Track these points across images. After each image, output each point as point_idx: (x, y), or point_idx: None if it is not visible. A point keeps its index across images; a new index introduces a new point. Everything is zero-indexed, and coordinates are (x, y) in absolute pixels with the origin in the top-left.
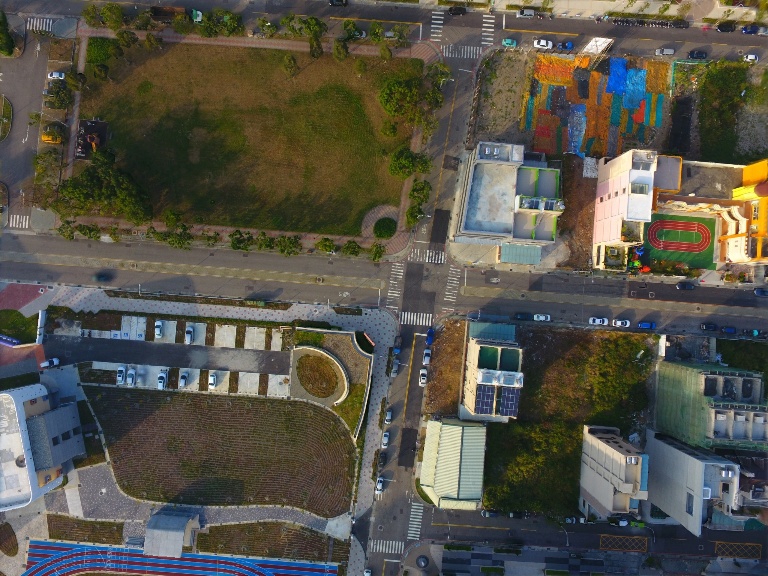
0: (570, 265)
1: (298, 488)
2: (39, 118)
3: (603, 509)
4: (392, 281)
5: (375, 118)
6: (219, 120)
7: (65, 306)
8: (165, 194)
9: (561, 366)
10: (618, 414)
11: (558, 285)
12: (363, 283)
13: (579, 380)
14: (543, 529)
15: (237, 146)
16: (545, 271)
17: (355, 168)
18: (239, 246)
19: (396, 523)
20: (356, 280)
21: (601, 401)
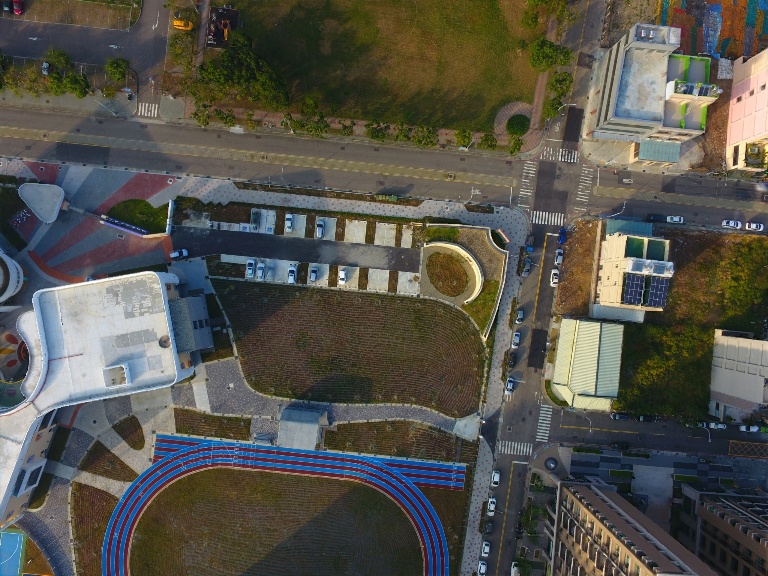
0: (704, 166)
1: (427, 387)
2: (174, 0)
3: (748, 404)
4: (524, 179)
5: (509, 13)
6: (351, 11)
7: (194, 197)
8: (296, 85)
9: (692, 270)
10: (749, 319)
11: (691, 187)
12: (495, 181)
13: (710, 284)
14: (672, 434)
15: (369, 38)
16: (678, 173)
17: (489, 63)
18: (378, 135)
19: (525, 424)
20: (488, 177)
21: (733, 305)
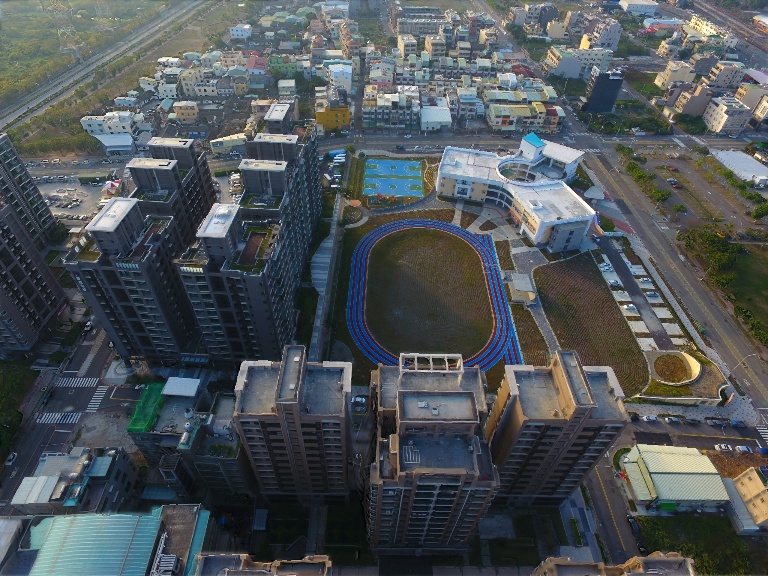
0: None
1: None
2: None
3: None
4: None
5: None
6: None
7: (630, 243)
8: None
9: None
10: None
11: None
12: (766, 396)
13: None
14: None
15: None
16: None
17: None
18: (740, 309)
19: None
20: (765, 390)
21: None
